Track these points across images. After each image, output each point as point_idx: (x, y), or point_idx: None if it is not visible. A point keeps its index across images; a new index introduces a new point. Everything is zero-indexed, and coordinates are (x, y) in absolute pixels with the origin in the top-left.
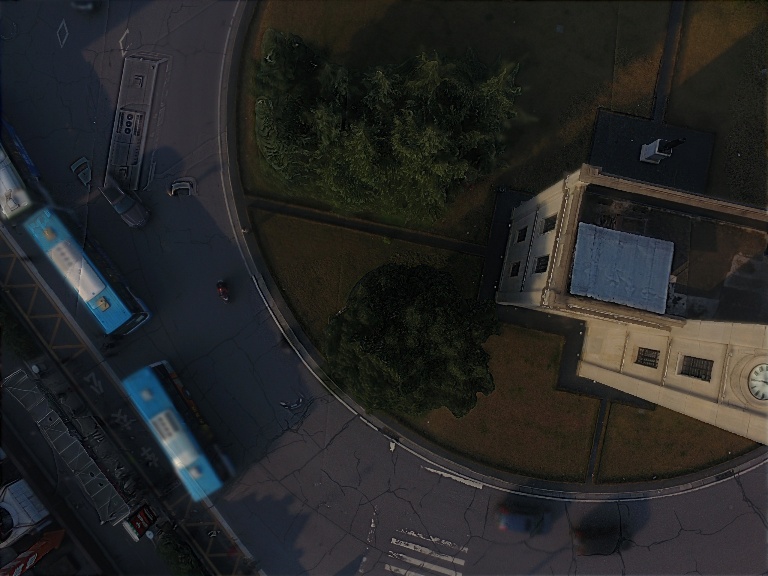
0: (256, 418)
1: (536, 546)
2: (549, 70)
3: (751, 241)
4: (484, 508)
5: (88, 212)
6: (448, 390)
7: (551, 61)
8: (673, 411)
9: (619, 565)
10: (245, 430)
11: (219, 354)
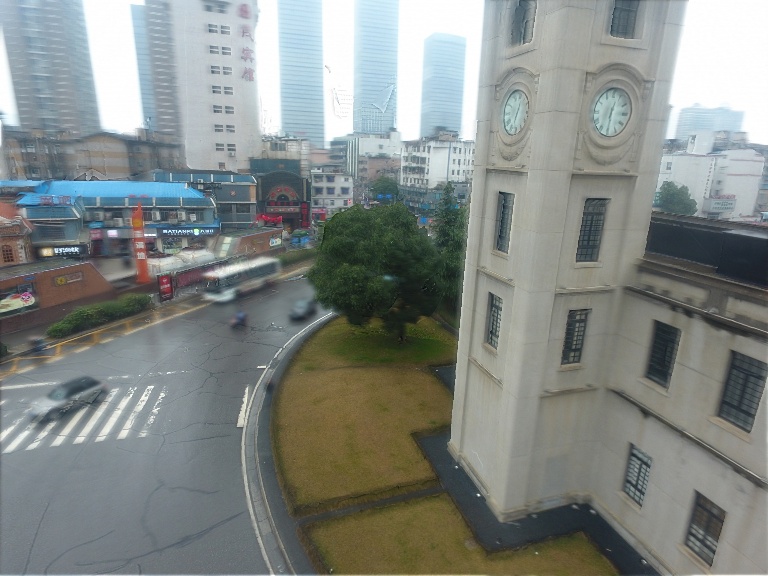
0: (255, 318)
1: (155, 501)
2: None
3: None
4: (210, 435)
5: None
6: None
7: None
8: None
9: None
10: (243, 316)
11: (296, 301)
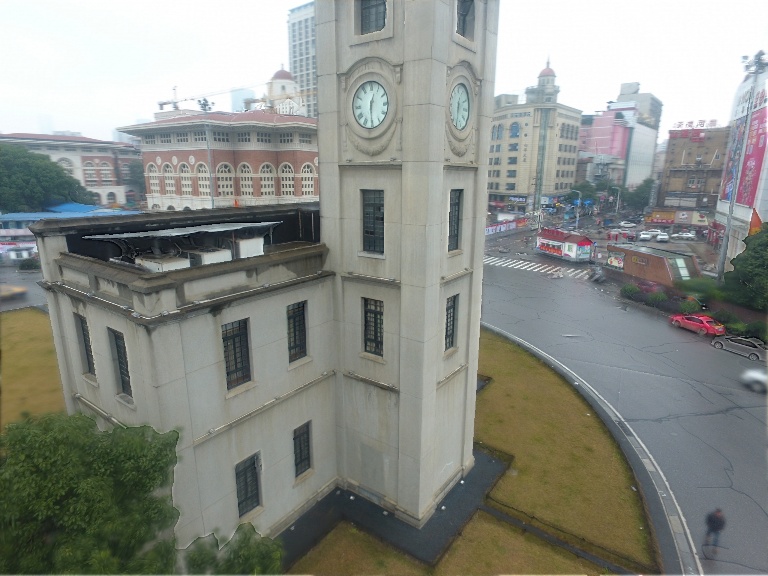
0: None
1: None
2: (9, 417)
3: (295, 244)
4: None
5: None
6: (80, 575)
7: (5, 413)
8: (519, 441)
9: None
10: None
11: None
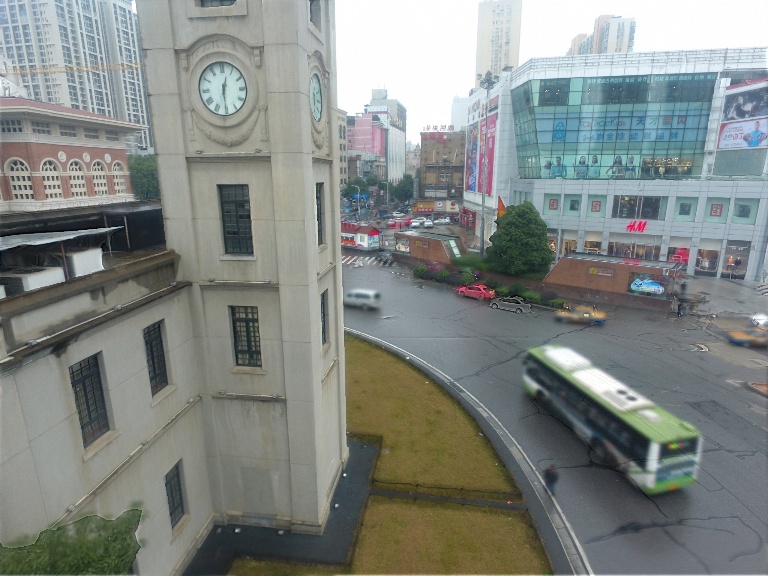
0: None
1: None
2: None
3: None
4: None
5: None
6: None
7: None
8: (381, 421)
9: (636, 465)
10: None
11: None
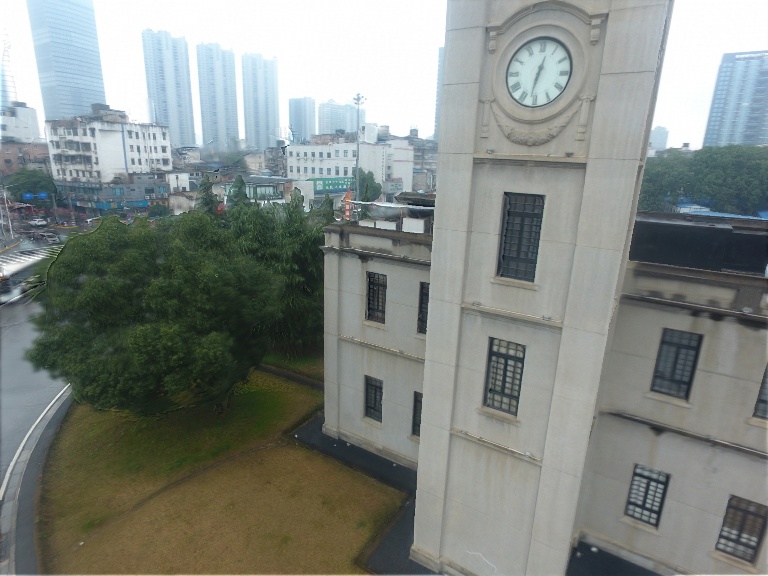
0: None
1: None
2: None
3: None
4: None
5: (40, 317)
6: None
7: None
8: None
9: None
10: None
11: None
